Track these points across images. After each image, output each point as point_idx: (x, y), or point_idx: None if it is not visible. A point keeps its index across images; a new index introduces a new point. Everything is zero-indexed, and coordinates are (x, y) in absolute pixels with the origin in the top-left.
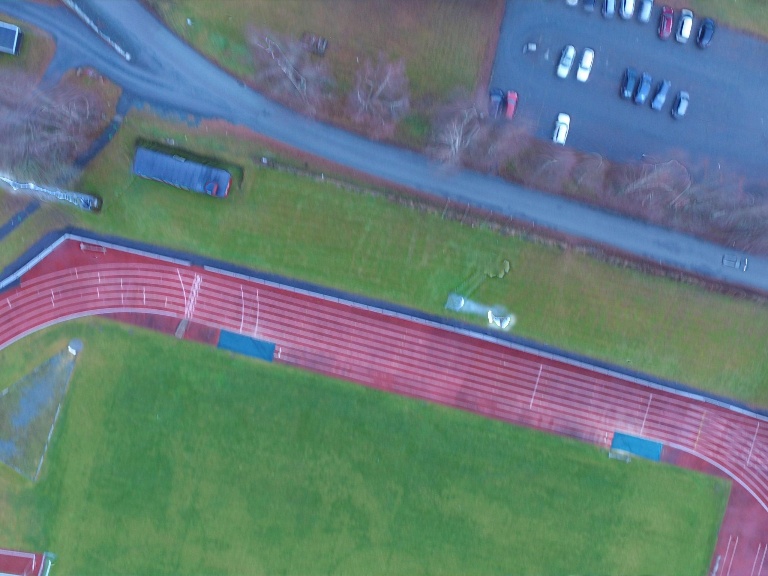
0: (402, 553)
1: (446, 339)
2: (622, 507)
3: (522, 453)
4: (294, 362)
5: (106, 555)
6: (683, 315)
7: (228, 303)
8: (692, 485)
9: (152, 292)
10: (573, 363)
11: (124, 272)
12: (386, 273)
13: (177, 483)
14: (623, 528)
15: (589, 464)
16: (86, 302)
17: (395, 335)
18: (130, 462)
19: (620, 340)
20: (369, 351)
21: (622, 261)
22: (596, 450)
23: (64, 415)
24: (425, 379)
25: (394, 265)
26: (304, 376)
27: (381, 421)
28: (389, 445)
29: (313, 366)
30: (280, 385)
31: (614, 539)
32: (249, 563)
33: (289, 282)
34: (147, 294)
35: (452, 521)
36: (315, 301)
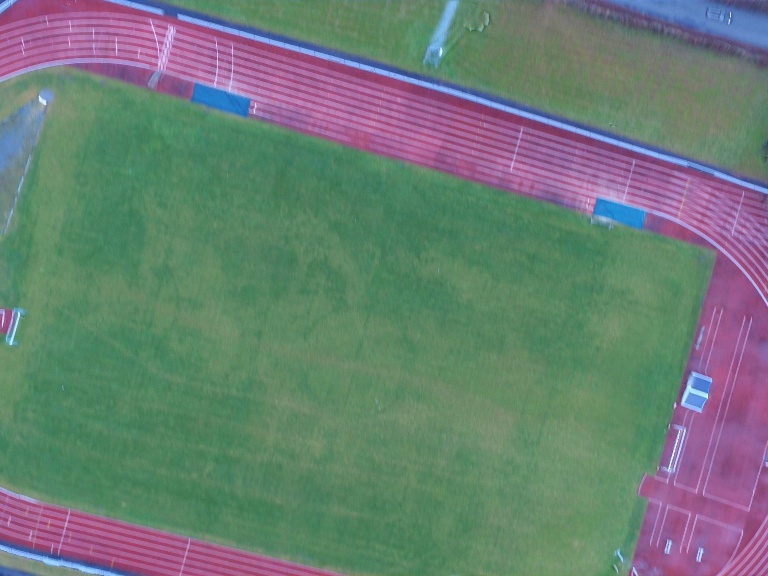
0: (379, 317)
1: (425, 98)
2: (604, 275)
3: (502, 217)
4: (269, 118)
5: (77, 312)
6: (666, 73)
7: (202, 56)
8: (676, 254)
9: (124, 43)
10: (554, 124)
11: (96, 21)
12: (363, 26)
13: (150, 239)
14: (605, 297)
15: (571, 230)
16: (57, 51)
17: (373, 93)
18: (102, 217)
19: (602, 101)
20: (346, 109)
21: (604, 10)
22: (578, 216)
23: (34, 167)
24: (403, 139)
25: (371, 17)
26: (280, 133)
27: (358, 181)
28: (366, 205)
29: (289, 123)
30: (255, 141)
31: (596, 308)
32: (223, 323)
33: (264, 35)
34: (119, 44)
35: (431, 285)
36: (291, 55)
